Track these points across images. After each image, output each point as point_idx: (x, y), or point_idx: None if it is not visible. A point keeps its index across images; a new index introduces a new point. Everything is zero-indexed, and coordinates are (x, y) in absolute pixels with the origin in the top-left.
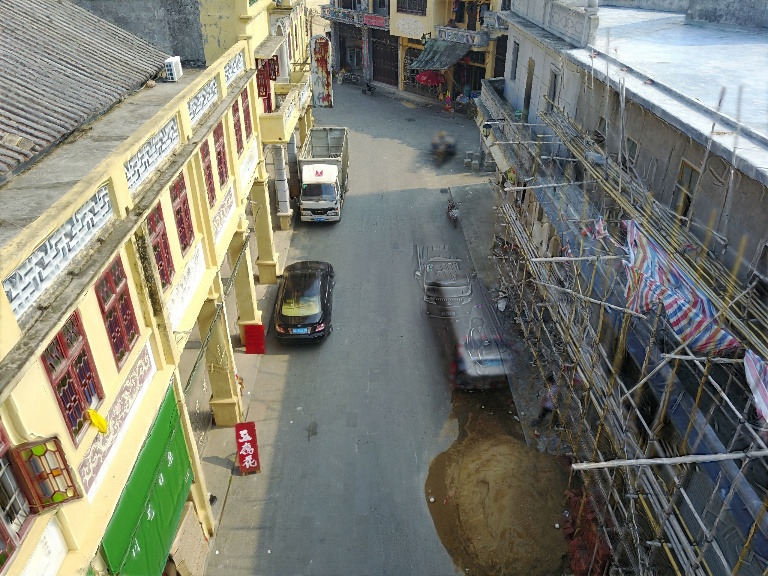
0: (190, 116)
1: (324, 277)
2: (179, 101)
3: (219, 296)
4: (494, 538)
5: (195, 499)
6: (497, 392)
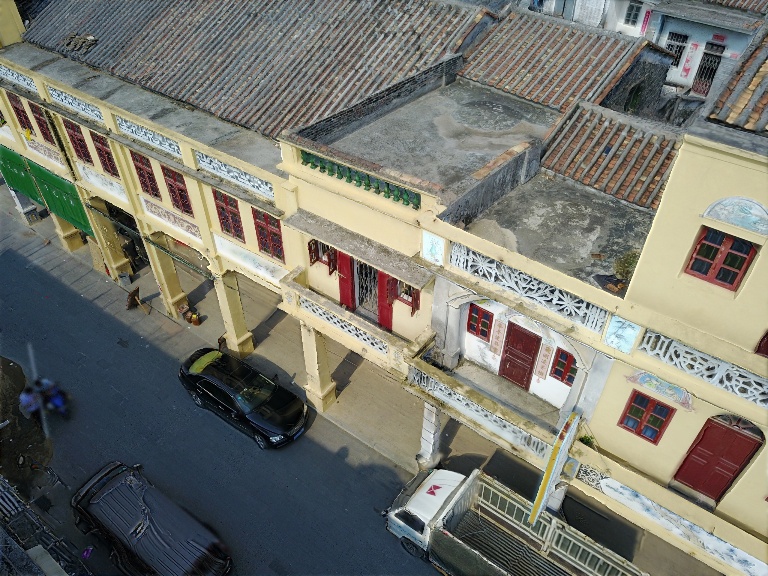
0: None
1: None
2: (104, 106)
3: None
4: None
5: None
6: (6, 462)
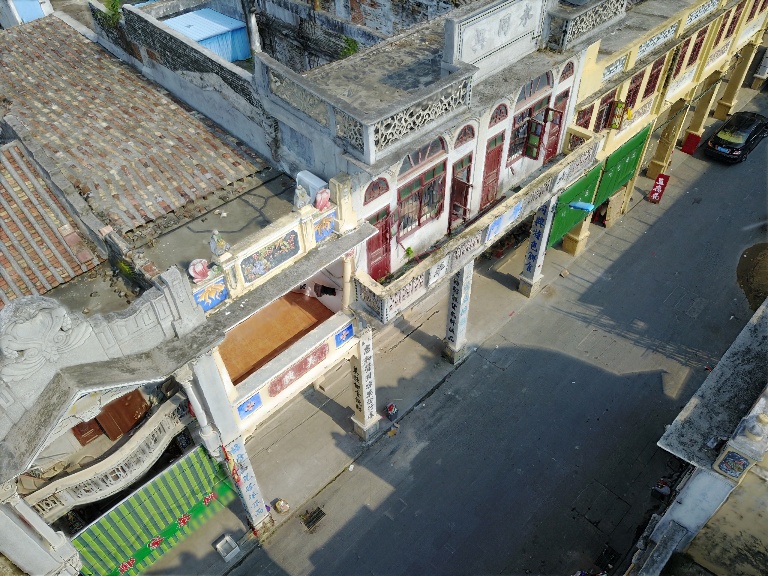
0: None
1: (761, 126)
2: None
3: (690, 100)
4: (767, 280)
5: (627, 189)
6: None
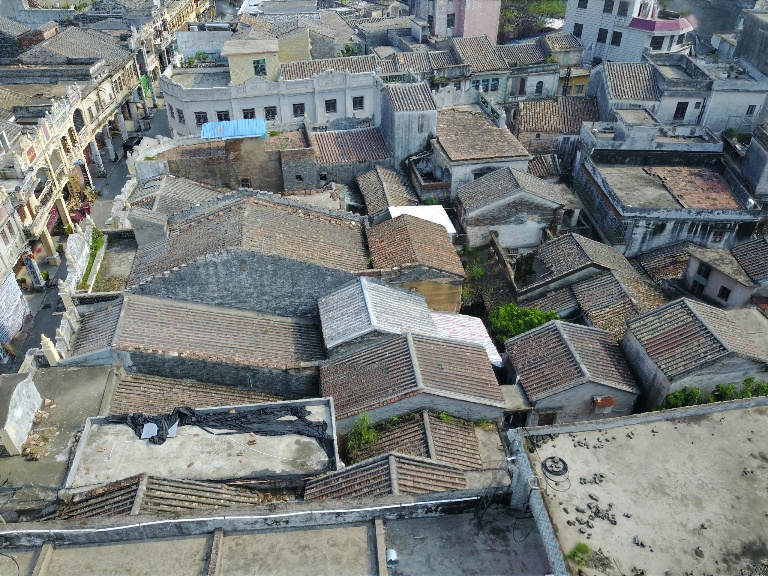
0: (183, 4)
1: None
2: (182, 2)
3: None
4: None
5: None
6: None
